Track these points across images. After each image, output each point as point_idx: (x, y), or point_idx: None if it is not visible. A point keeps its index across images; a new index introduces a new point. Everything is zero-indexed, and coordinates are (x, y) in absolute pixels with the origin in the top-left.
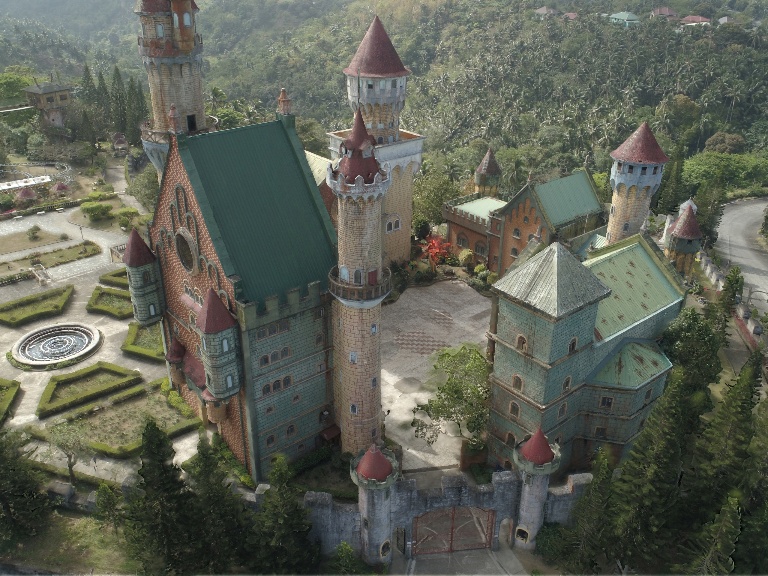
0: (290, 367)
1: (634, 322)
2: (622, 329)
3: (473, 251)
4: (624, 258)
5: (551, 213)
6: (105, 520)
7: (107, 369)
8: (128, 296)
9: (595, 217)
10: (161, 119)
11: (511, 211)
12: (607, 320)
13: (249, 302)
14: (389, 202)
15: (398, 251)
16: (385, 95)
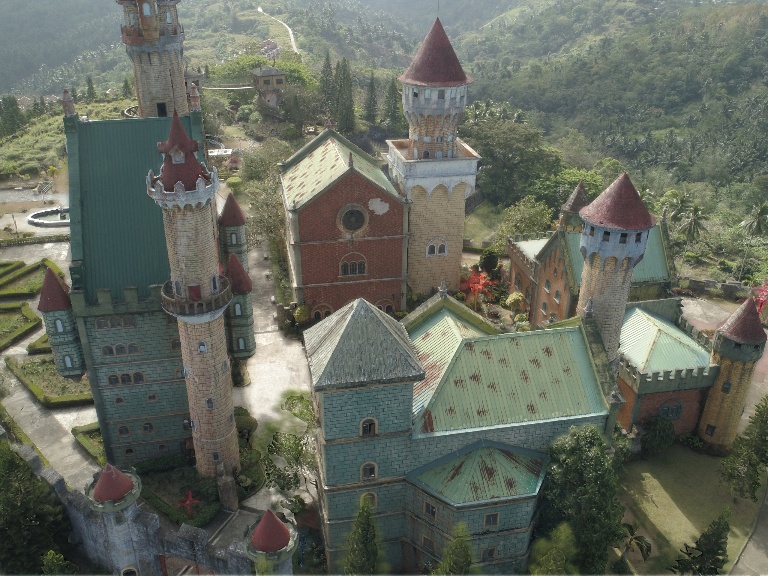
0: (141, 364)
1: (499, 423)
2: (473, 427)
3: (524, 296)
4: (539, 341)
5: None
6: None
7: None
8: None
9: (657, 287)
10: None
11: (545, 258)
12: (456, 410)
13: (78, 289)
14: (432, 223)
15: None
16: (430, 106)
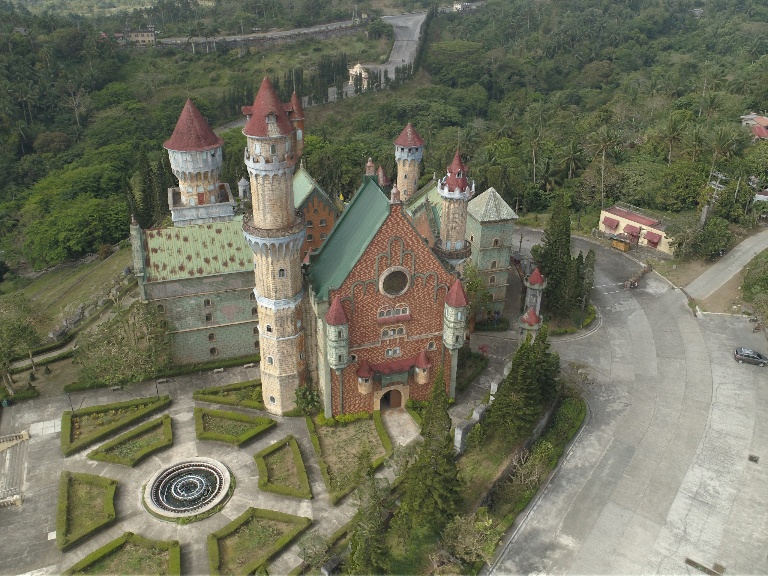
0: None
1: None
2: None
3: None
4: None
5: None
6: (482, 446)
7: (267, 454)
8: (135, 434)
9: None
10: (284, 216)
11: None
12: None
13: (463, 279)
14: None
15: None
16: None
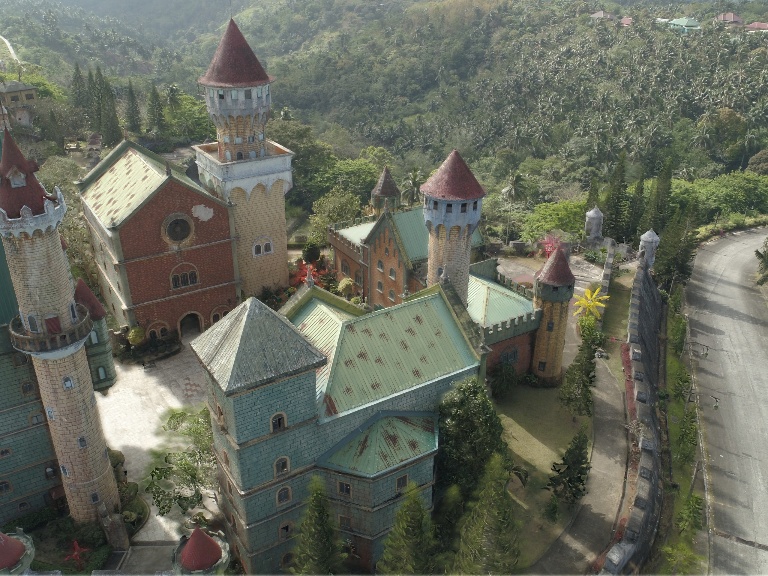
0: None
1: (393, 393)
2: (371, 401)
3: (353, 280)
4: (409, 312)
5: (411, 245)
6: None
7: None
8: None
9: (474, 251)
10: None
11: (374, 240)
12: (353, 389)
13: None
14: (255, 223)
15: (272, 276)
16: (238, 106)
